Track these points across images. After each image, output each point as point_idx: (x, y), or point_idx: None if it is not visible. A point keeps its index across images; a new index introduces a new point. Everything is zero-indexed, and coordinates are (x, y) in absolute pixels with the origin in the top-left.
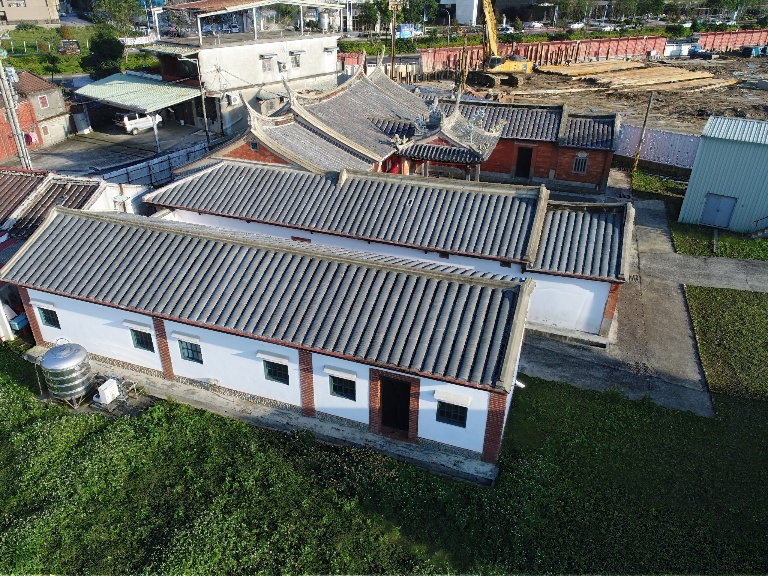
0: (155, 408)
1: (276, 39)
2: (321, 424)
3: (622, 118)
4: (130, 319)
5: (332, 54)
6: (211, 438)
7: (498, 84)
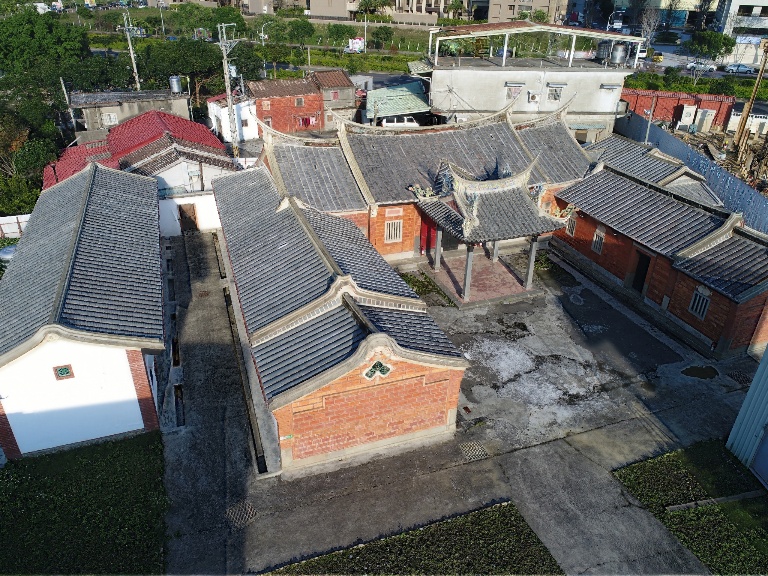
0: None
1: (530, 68)
2: None
3: None
4: None
5: (613, 92)
6: None
7: None
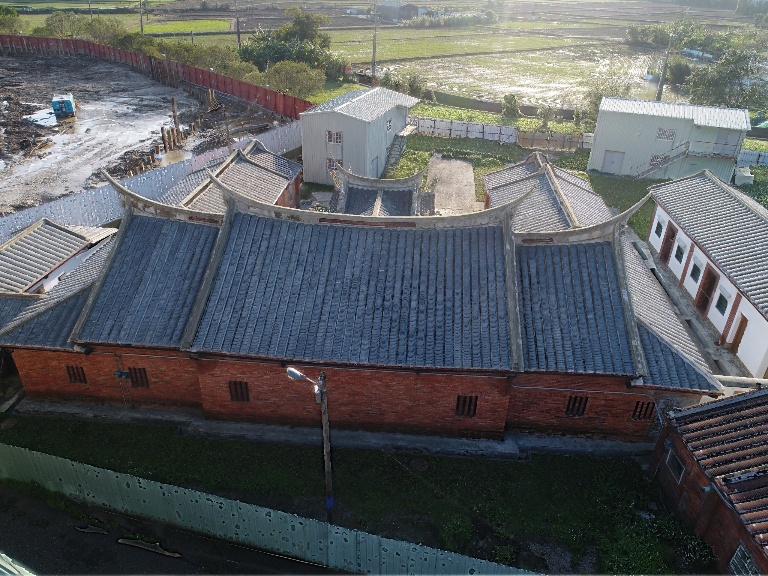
0: None
1: None
2: None
3: (6, 178)
4: None
5: None
6: None
7: None
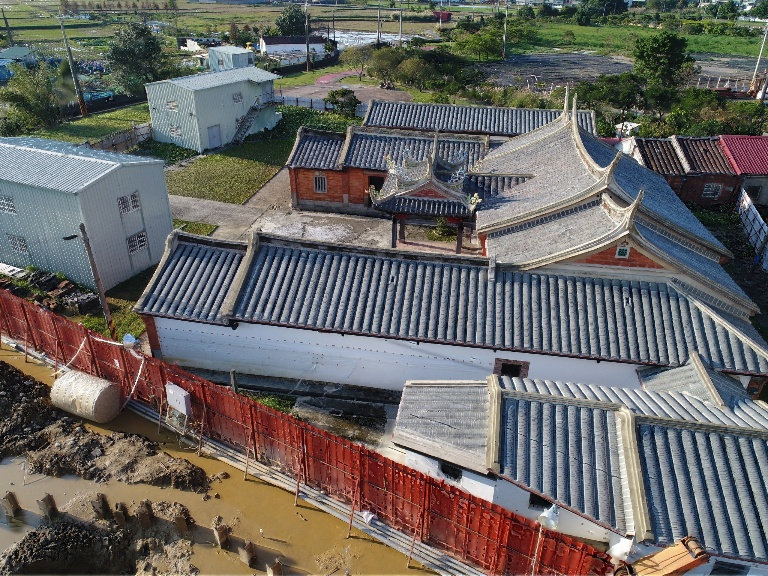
0: None
1: None
2: None
3: None
4: None
5: None
6: None
7: None
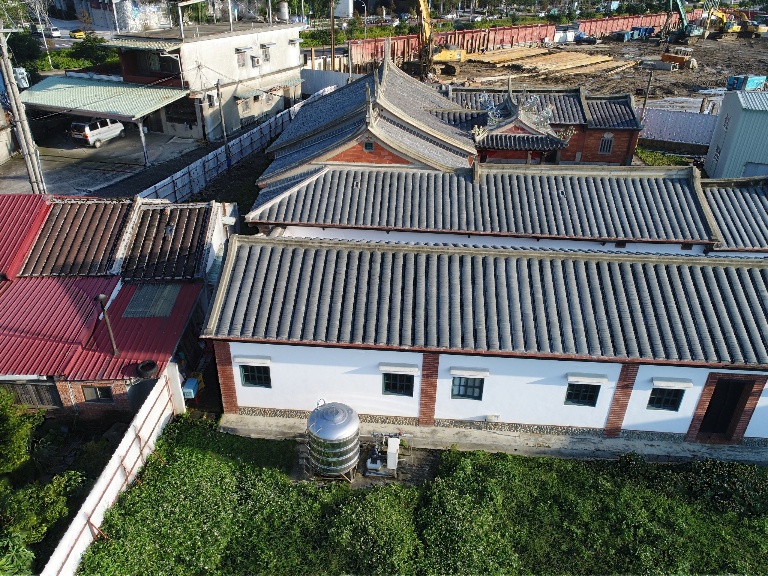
0: (466, 462)
1: (249, 31)
2: (631, 443)
3: None
4: (388, 361)
5: (295, 46)
6: (549, 484)
7: (439, 73)
